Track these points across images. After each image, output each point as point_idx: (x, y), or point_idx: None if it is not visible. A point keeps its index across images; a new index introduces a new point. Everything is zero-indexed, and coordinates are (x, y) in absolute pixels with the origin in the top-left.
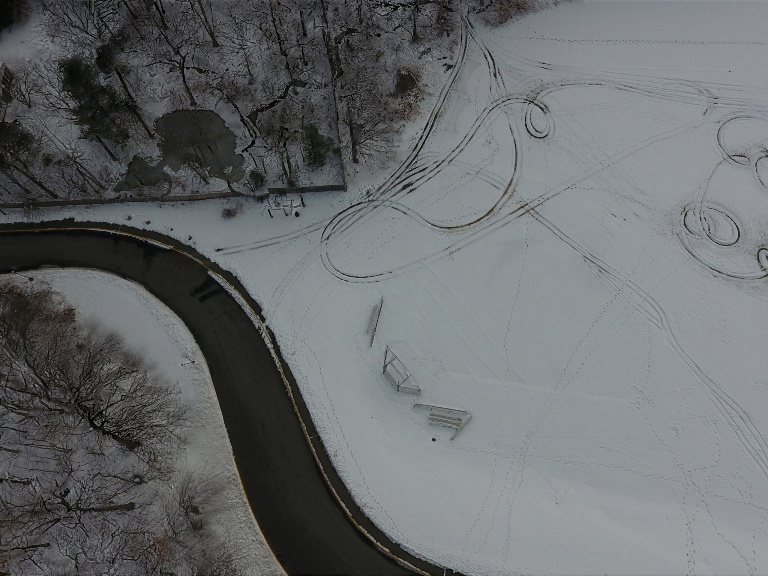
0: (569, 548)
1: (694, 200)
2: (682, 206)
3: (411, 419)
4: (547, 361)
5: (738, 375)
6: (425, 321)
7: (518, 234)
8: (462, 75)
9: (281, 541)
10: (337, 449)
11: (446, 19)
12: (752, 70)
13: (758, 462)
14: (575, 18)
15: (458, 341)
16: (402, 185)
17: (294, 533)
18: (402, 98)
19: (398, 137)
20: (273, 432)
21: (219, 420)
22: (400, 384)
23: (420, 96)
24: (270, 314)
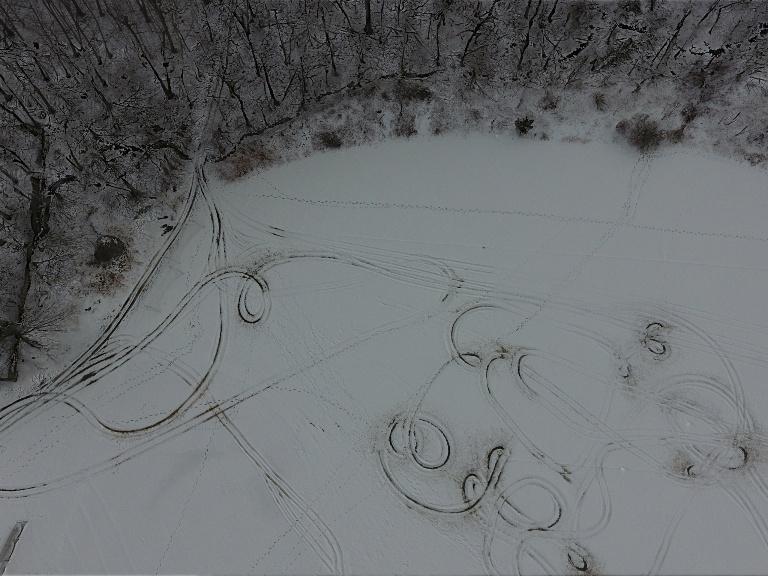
0: None
1: (407, 409)
2: (391, 417)
3: None
4: None
5: None
6: (69, 549)
7: (199, 443)
8: (180, 240)
9: None
10: None
11: (177, 169)
12: (509, 247)
13: None
14: (324, 173)
15: None
16: (83, 375)
17: None
18: (105, 267)
19: (74, 325)
20: None
21: None
22: None
23: (126, 265)
24: None
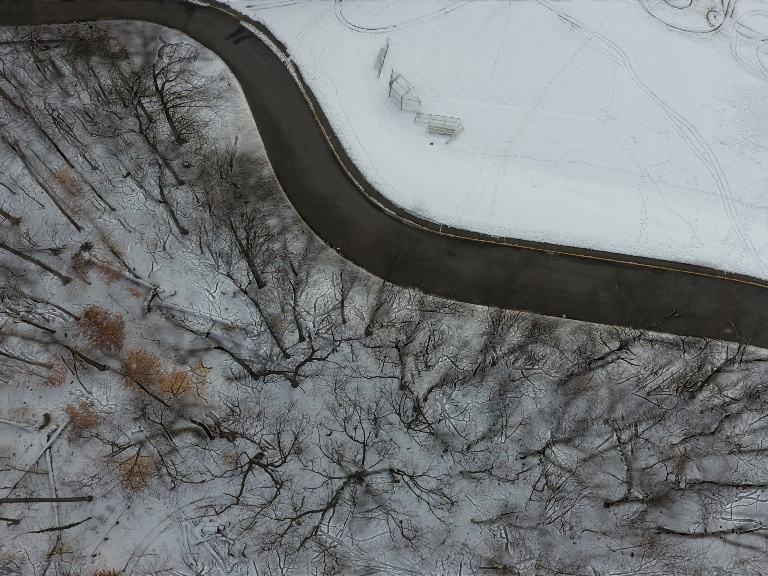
0: (543, 212)
1: None
2: None
3: (413, 129)
4: (527, 90)
5: (688, 100)
6: (424, 61)
7: None
8: None
9: (306, 208)
10: (351, 145)
11: None
12: None
13: (702, 160)
14: None
15: (452, 75)
16: None
17: (317, 202)
18: None
19: None
20: (298, 134)
21: (253, 125)
22: (403, 96)
23: None
24: (293, 51)
